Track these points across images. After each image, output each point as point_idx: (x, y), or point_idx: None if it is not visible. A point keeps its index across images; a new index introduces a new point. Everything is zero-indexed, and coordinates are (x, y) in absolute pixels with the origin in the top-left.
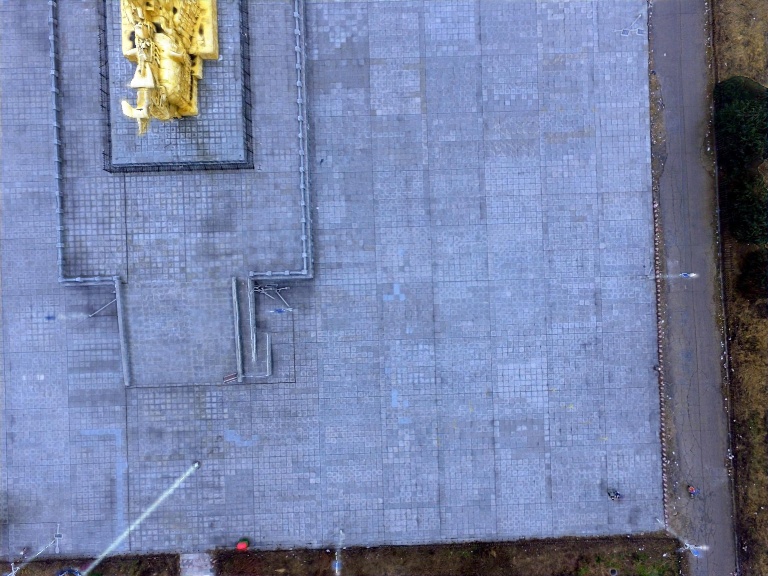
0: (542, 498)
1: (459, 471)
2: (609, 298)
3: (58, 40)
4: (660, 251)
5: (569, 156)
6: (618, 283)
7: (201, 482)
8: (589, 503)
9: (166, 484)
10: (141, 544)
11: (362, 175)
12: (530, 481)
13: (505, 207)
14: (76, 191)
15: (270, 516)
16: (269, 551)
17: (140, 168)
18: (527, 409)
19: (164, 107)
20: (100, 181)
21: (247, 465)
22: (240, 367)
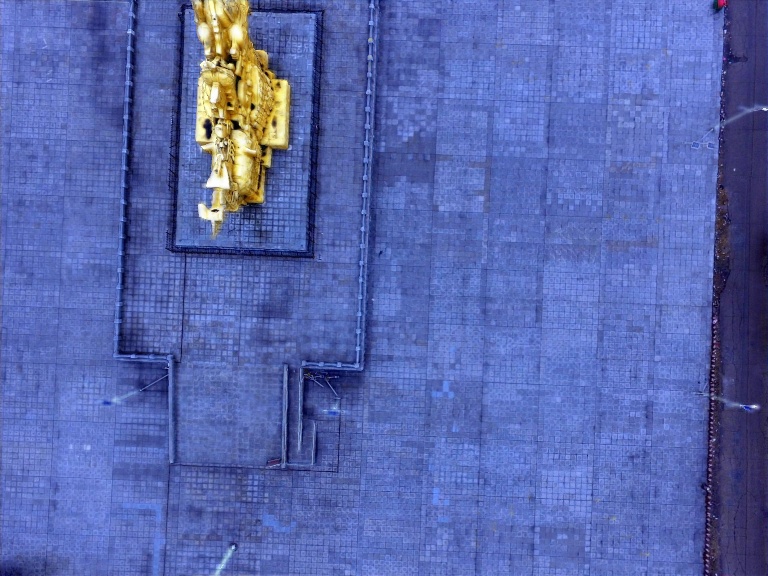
0: None
1: (496, 575)
2: (661, 412)
3: (132, 118)
4: (716, 368)
5: (630, 265)
6: (671, 397)
7: (237, 564)
8: None
9: (202, 564)
10: None
11: (420, 270)
12: None
13: (561, 312)
14: (137, 268)
15: None
16: None
17: (202, 250)
18: (569, 518)
19: (235, 202)
20: (161, 259)
21: (284, 551)
22: (285, 454)
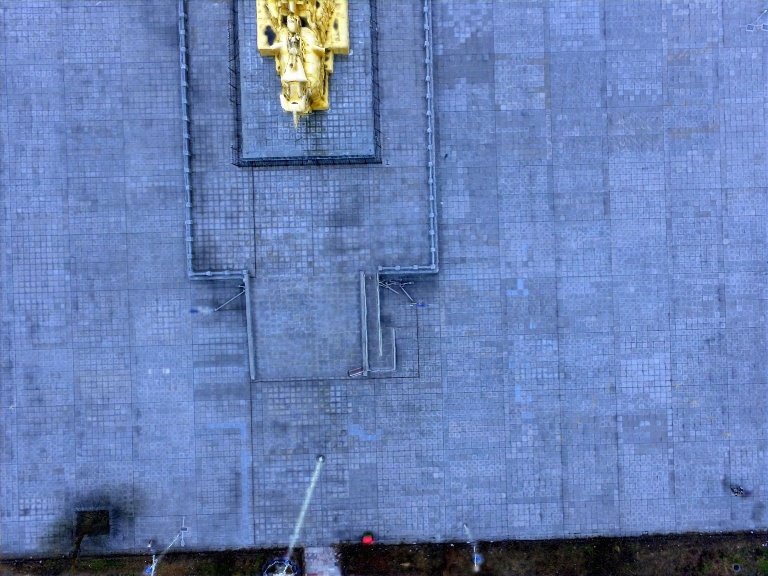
0: (665, 493)
1: (582, 466)
2: (733, 294)
3: (188, 34)
4: None
5: (693, 151)
6: (742, 279)
7: (325, 476)
8: (712, 499)
9: (290, 478)
10: (266, 537)
11: (486, 170)
12: (653, 476)
13: (629, 202)
14: (205, 185)
15: (394, 510)
16: (393, 545)
17: (268, 162)
18: (650, 404)
19: None
20: (229, 175)
21: (371, 459)
22: (367, 361)
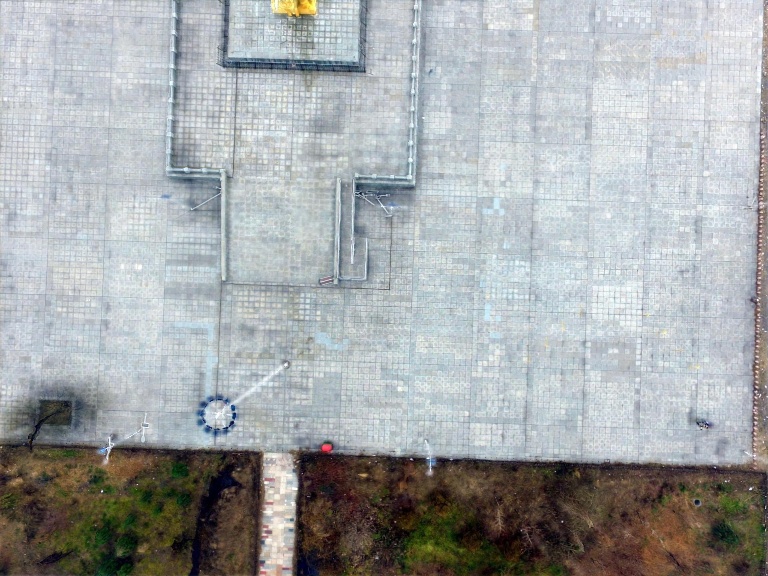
0: (629, 423)
1: (547, 390)
2: (710, 226)
3: None
4: (764, 183)
5: (678, 82)
6: (720, 212)
7: (289, 382)
8: (677, 431)
9: (255, 382)
10: (226, 439)
11: (470, 88)
12: (618, 405)
13: (611, 129)
14: (188, 83)
15: (356, 421)
16: (352, 456)
17: (253, 65)
18: (620, 332)
19: None
20: (213, 75)
21: (336, 368)
22: (338, 268)
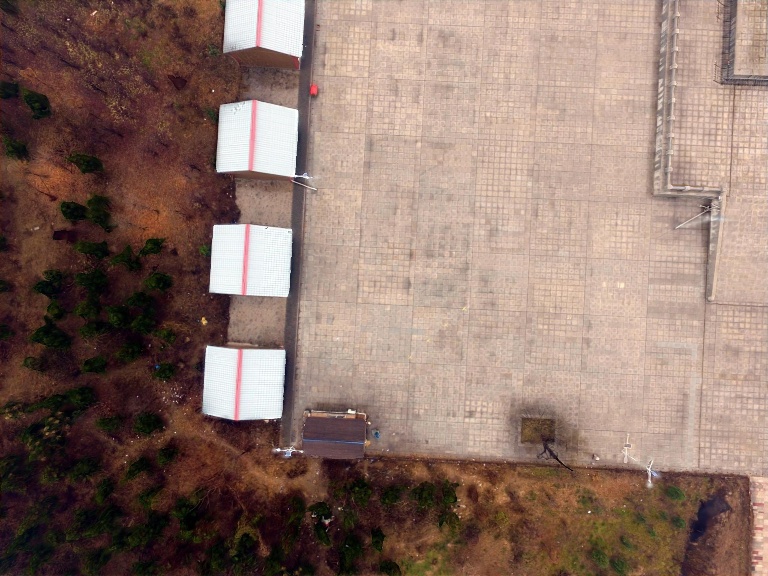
0: None
1: None
2: None
3: None
4: None
5: None
6: None
7: None
8: None
9: (739, 404)
10: (710, 462)
11: None
12: None
13: None
14: (685, 100)
15: None
16: None
17: (752, 82)
18: None
19: None
20: (710, 92)
21: None
22: None
